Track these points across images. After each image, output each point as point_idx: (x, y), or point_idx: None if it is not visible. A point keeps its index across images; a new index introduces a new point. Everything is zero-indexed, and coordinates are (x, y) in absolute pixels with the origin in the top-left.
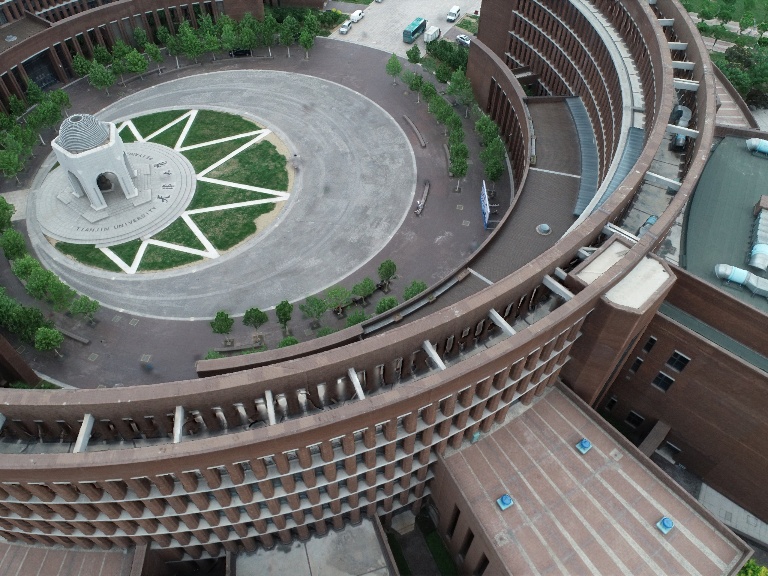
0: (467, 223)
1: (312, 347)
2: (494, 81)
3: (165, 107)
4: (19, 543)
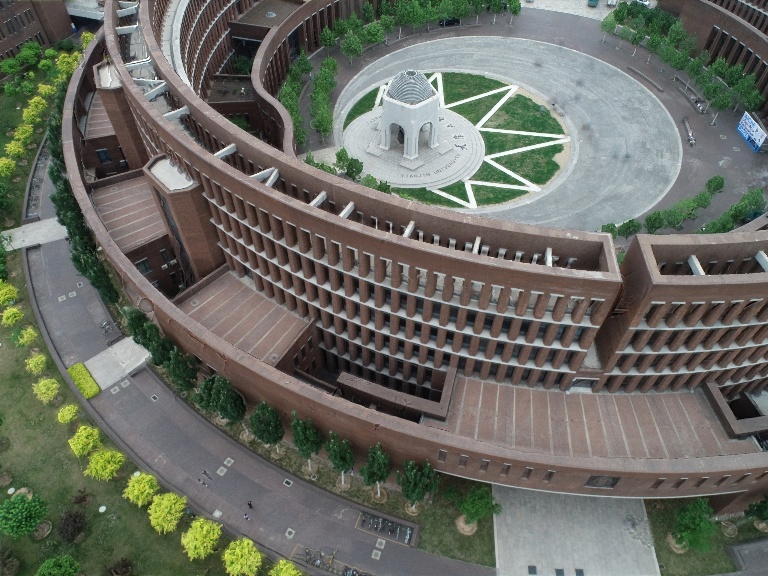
0: (737, 149)
1: None
2: (717, 29)
3: None
4: (602, 393)
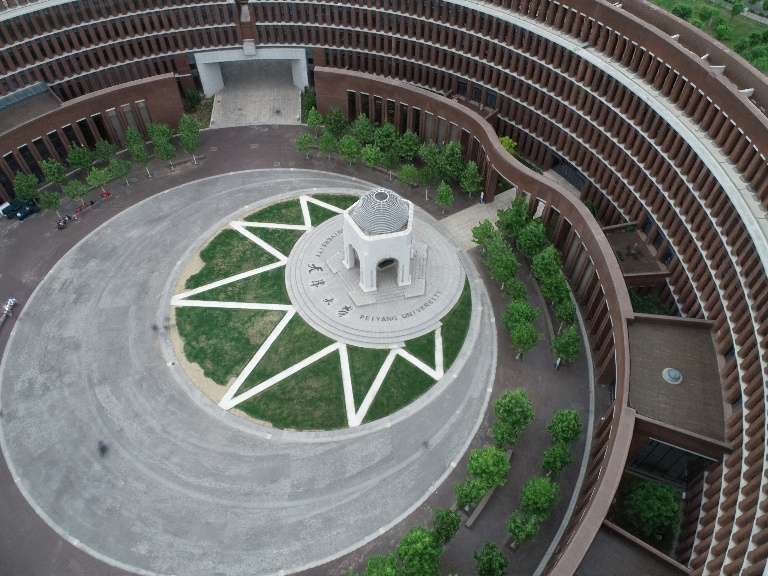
0: None
1: (98, 92)
2: None
3: (403, 419)
4: None
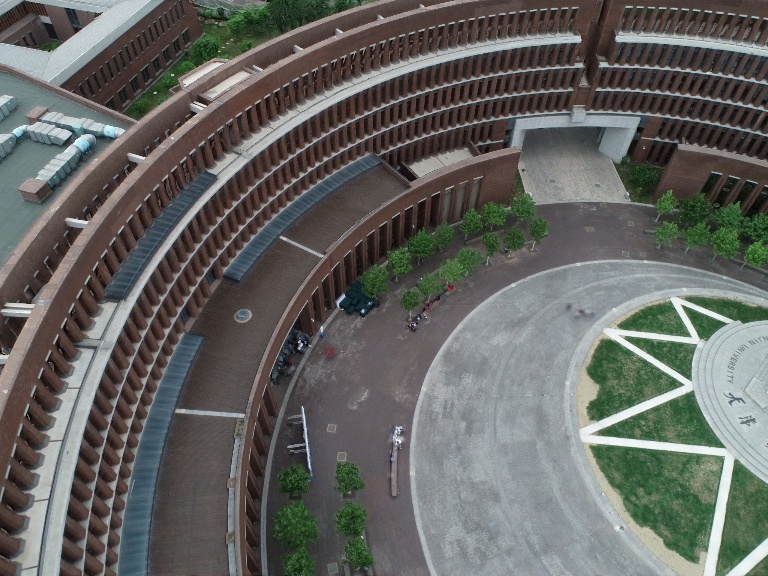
0: (331, 428)
1: (444, 169)
2: None
3: None
4: None
